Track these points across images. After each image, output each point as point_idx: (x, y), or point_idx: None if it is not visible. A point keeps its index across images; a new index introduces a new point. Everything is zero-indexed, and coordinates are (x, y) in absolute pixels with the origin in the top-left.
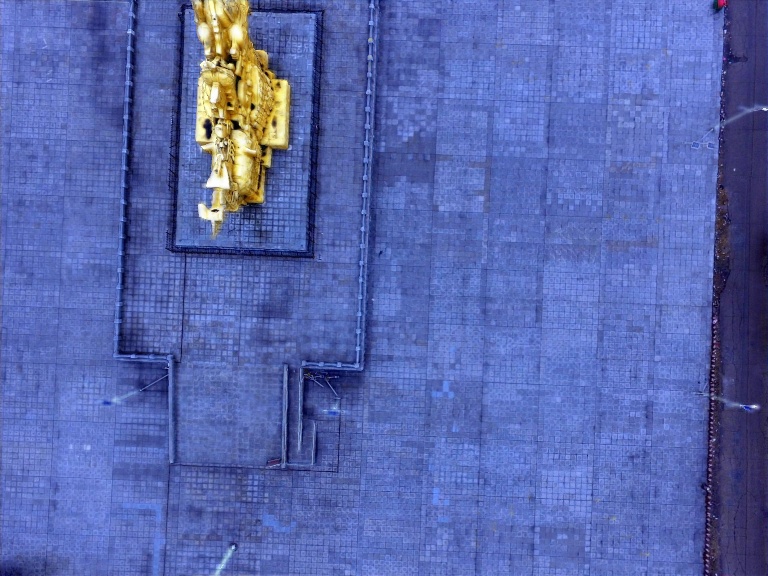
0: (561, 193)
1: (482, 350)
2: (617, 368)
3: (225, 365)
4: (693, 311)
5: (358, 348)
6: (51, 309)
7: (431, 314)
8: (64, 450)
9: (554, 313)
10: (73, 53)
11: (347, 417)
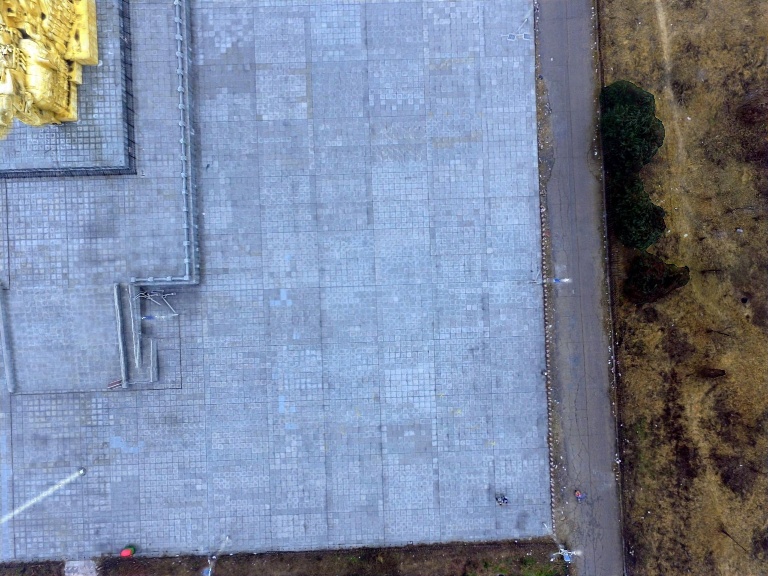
0: (383, 94)
1: (317, 256)
2: (451, 263)
3: (55, 289)
4: (521, 201)
5: (186, 260)
6: None
7: (263, 224)
8: None
9: (385, 214)
10: None
11: (187, 333)
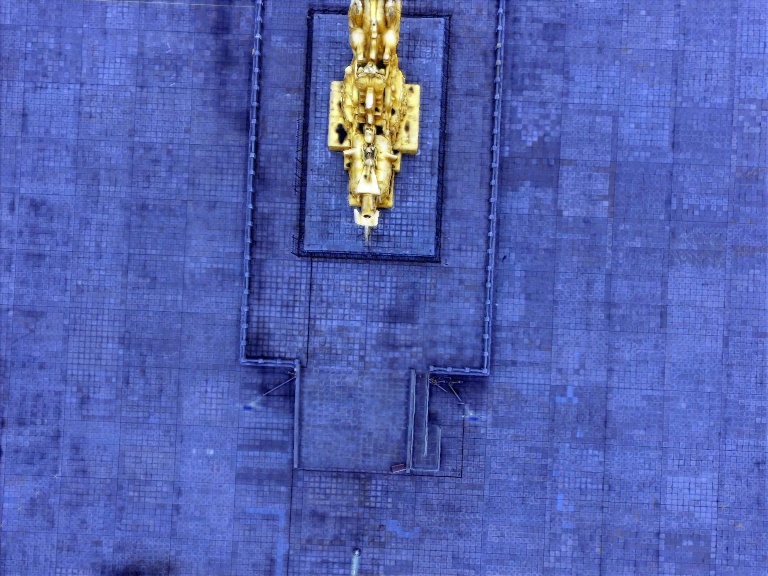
0: (686, 198)
1: (606, 355)
2: (743, 374)
3: (351, 370)
4: None
5: (486, 353)
6: (174, 313)
7: (555, 319)
8: (187, 454)
9: (679, 318)
10: (197, 57)
11: (471, 422)
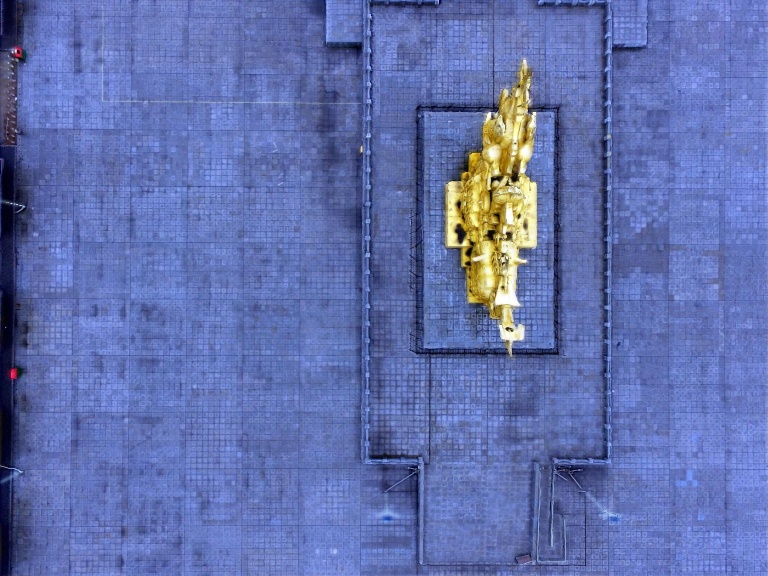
0: None
1: (723, 437)
2: None
3: (474, 465)
4: None
5: (610, 443)
6: (291, 413)
7: (671, 403)
8: (310, 555)
9: None
10: (303, 156)
11: (592, 510)
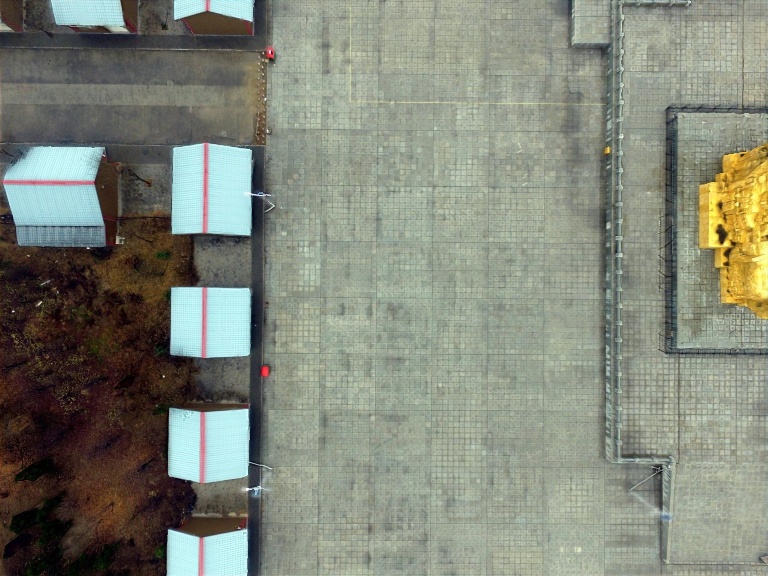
0: None
1: None
2: None
3: (723, 464)
4: None
5: None
6: (536, 412)
7: None
8: (555, 553)
9: None
10: (548, 156)
11: None
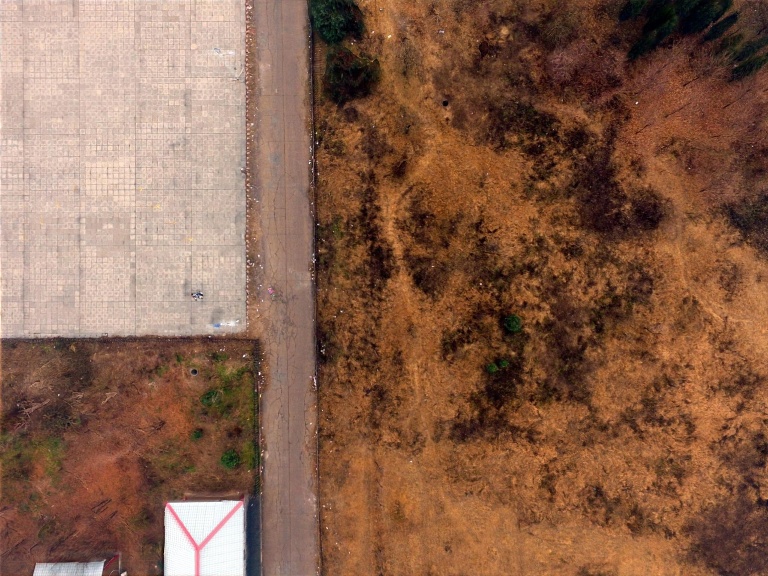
0: None
1: (21, 46)
2: (155, 58)
3: None
4: None
5: None
6: None
7: None
8: None
9: (91, 7)
10: None
11: None
